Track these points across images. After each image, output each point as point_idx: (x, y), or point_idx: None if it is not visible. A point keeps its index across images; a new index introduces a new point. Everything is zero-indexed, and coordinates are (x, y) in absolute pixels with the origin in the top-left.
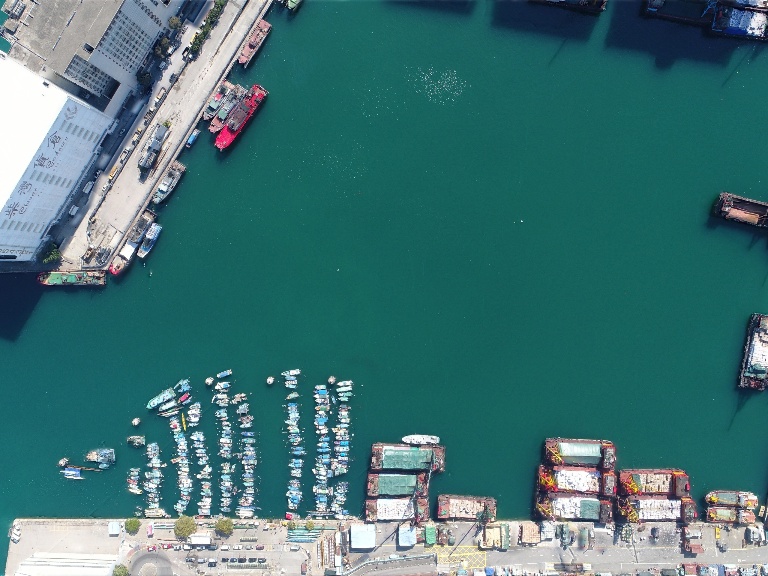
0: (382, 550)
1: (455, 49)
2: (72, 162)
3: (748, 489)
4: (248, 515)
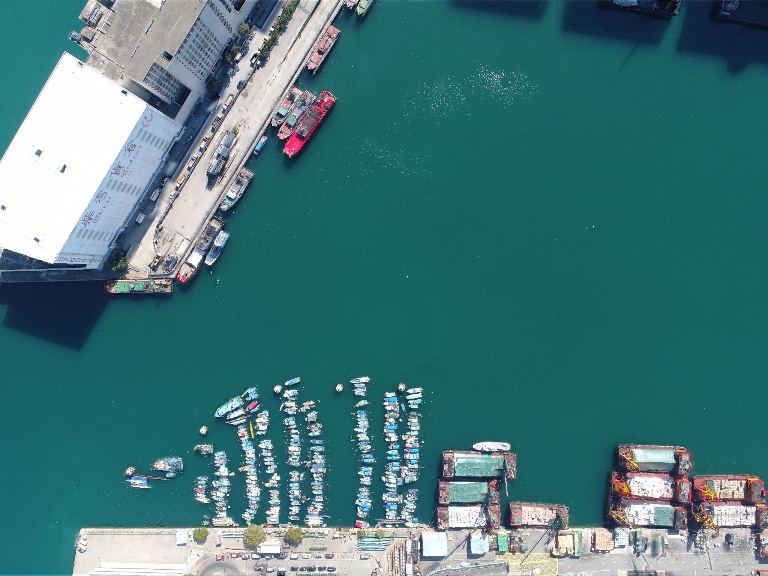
0: (453, 558)
1: (525, 54)
2: (143, 170)
3: None
4: (317, 523)
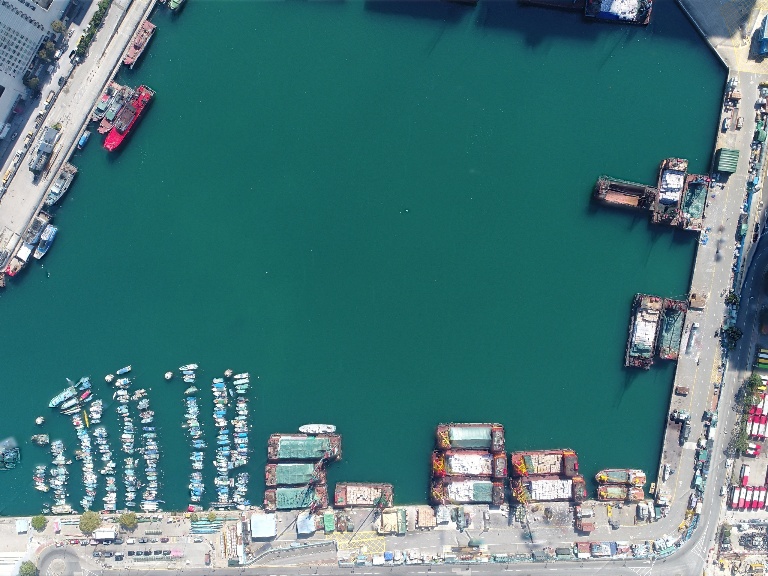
0: (283, 539)
1: (336, 43)
2: None
3: (638, 467)
4: (152, 509)
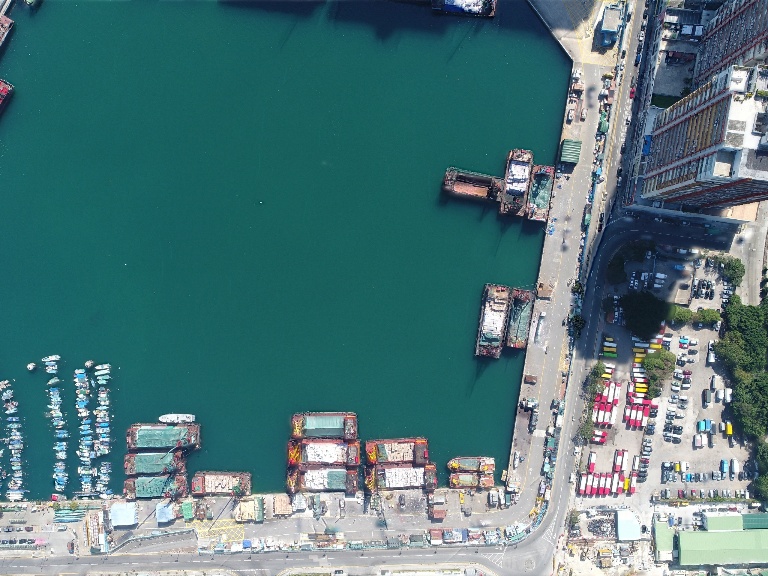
0: (145, 527)
1: (191, 37)
2: None
3: (491, 454)
4: (17, 498)
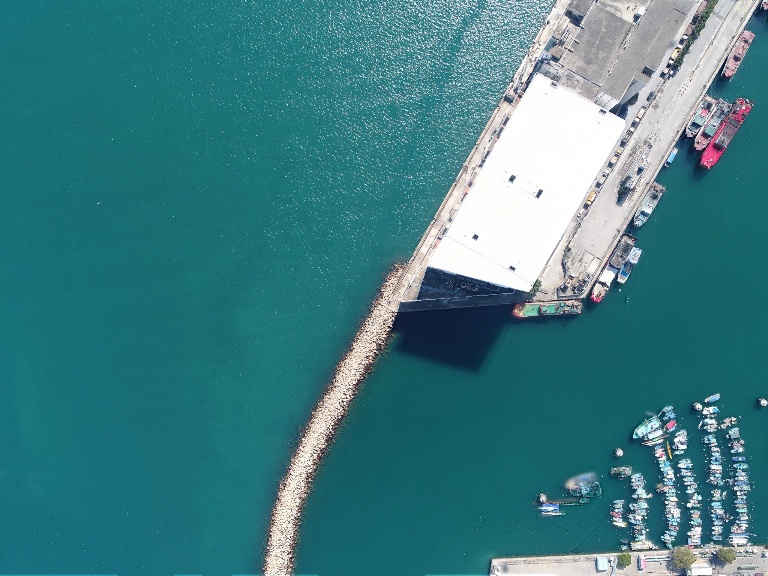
0: None
1: None
2: None
3: None
4: (742, 542)
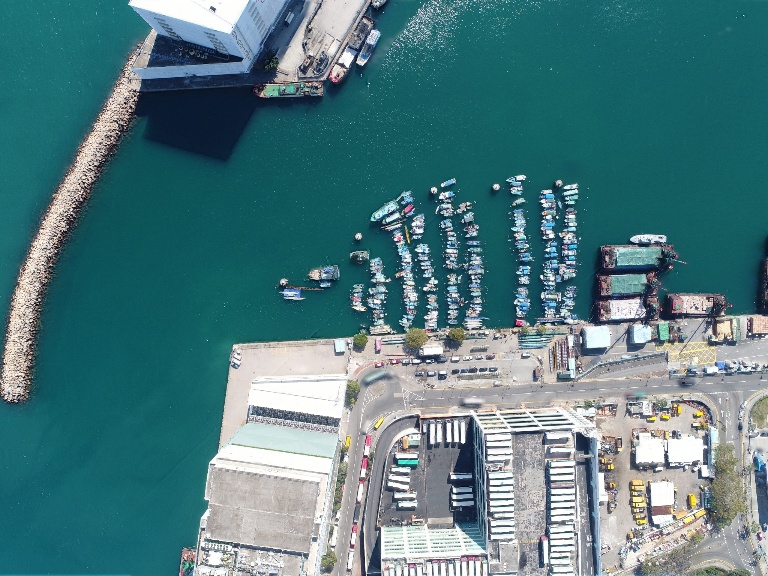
0: (613, 352)
1: None
2: None
3: None
4: (476, 326)
